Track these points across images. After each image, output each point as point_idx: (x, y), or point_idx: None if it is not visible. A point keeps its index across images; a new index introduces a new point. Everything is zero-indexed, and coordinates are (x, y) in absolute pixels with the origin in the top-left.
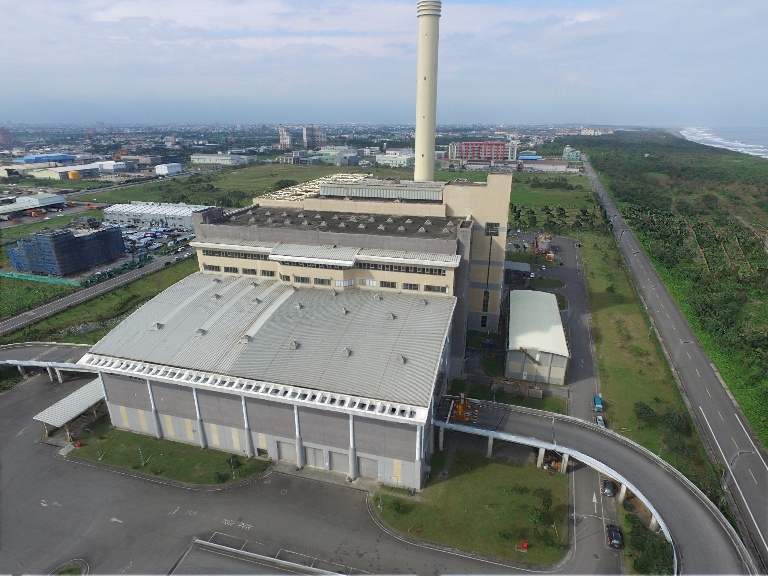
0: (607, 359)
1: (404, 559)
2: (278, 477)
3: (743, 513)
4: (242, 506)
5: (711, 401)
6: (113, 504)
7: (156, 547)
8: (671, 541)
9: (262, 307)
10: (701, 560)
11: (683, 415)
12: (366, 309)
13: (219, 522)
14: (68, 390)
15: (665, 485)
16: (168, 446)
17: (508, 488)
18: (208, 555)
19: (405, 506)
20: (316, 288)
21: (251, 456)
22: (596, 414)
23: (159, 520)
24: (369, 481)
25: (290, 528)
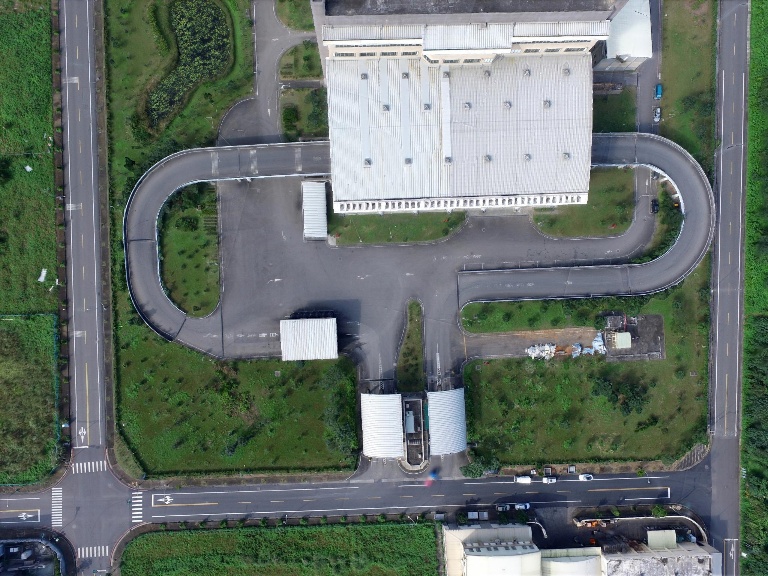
0: (671, 18)
1: (559, 249)
2: (475, 221)
3: (718, 170)
4: (468, 246)
5: (733, 61)
6: (399, 266)
7: (442, 281)
8: (684, 213)
9: (436, 115)
10: (694, 218)
11: (711, 89)
12: (523, 96)
13: (462, 259)
14: (266, 188)
15: (689, 175)
16: (394, 219)
17: (603, 191)
18: (469, 276)
19: (552, 219)
20: (465, 66)
21: (451, 211)
22: (655, 102)
23: (431, 267)
24: (527, 208)
25: (500, 251)
